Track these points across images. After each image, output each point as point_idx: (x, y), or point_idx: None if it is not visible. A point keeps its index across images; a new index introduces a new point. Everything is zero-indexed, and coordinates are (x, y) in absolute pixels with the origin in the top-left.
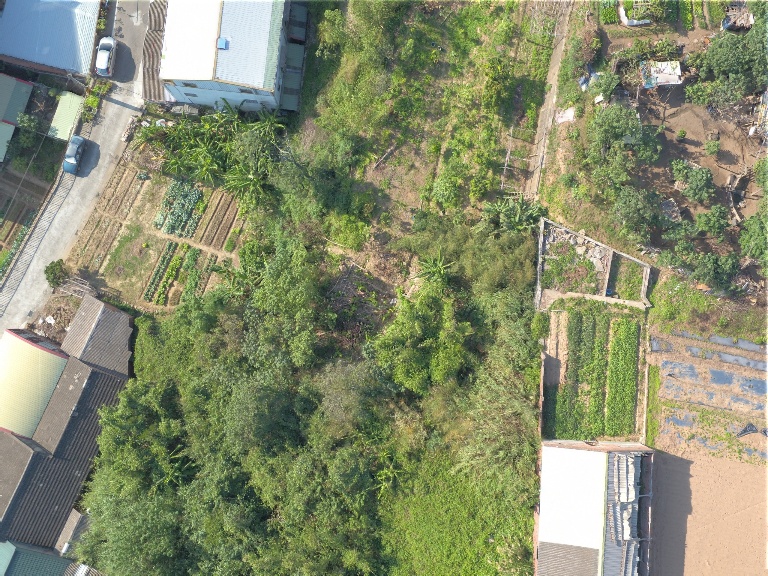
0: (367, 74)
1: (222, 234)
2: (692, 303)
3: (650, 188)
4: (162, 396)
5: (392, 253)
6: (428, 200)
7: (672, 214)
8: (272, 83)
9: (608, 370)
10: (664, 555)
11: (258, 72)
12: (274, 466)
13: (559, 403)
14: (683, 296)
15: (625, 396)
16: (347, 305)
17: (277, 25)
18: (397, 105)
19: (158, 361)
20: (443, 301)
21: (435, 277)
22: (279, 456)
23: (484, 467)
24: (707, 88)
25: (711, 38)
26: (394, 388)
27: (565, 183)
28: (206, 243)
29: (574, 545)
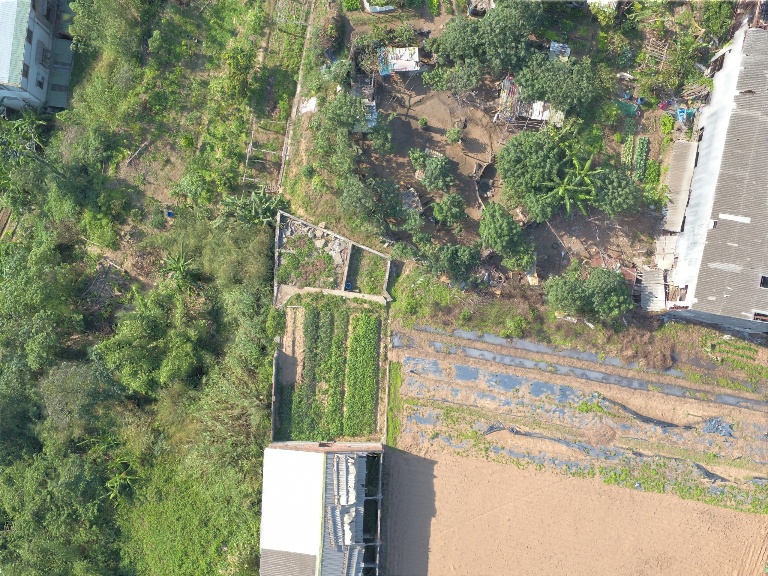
0: (122, 68)
1: None
2: (435, 296)
3: (395, 178)
4: None
5: (148, 251)
6: (185, 196)
7: (412, 204)
8: (18, 78)
9: (346, 367)
10: (406, 560)
11: (2, 67)
12: (12, 475)
13: (295, 403)
14: (426, 289)
15: (364, 394)
16: (104, 306)
17: (24, 18)
18: (150, 99)
19: None
20: (176, 299)
21: (176, 274)
22: (14, 464)
23: (212, 471)
24: None
25: None
26: (122, 390)
27: (304, 174)
28: None
29: (293, 551)
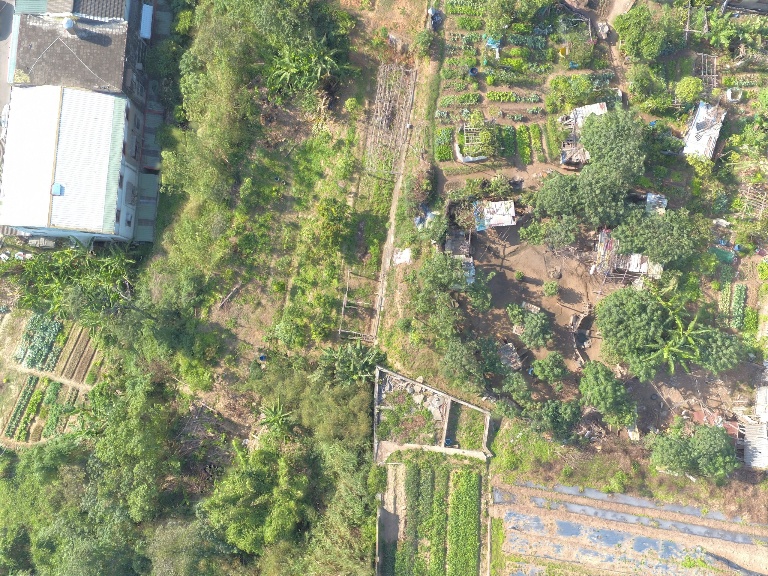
0: (212, 210)
1: (83, 367)
2: (535, 451)
3: (491, 330)
4: (12, 546)
5: (241, 394)
6: (276, 338)
7: (511, 359)
8: (112, 226)
9: (448, 525)
10: None
11: (96, 216)
12: None
13: (397, 561)
14: (525, 444)
15: (466, 552)
16: (197, 448)
17: (116, 166)
18: (241, 243)
19: (11, 507)
20: (277, 456)
21: (274, 426)
22: None
23: None
24: (542, 228)
25: (543, 178)
26: (226, 550)
27: (401, 329)
28: (67, 377)
29: None
